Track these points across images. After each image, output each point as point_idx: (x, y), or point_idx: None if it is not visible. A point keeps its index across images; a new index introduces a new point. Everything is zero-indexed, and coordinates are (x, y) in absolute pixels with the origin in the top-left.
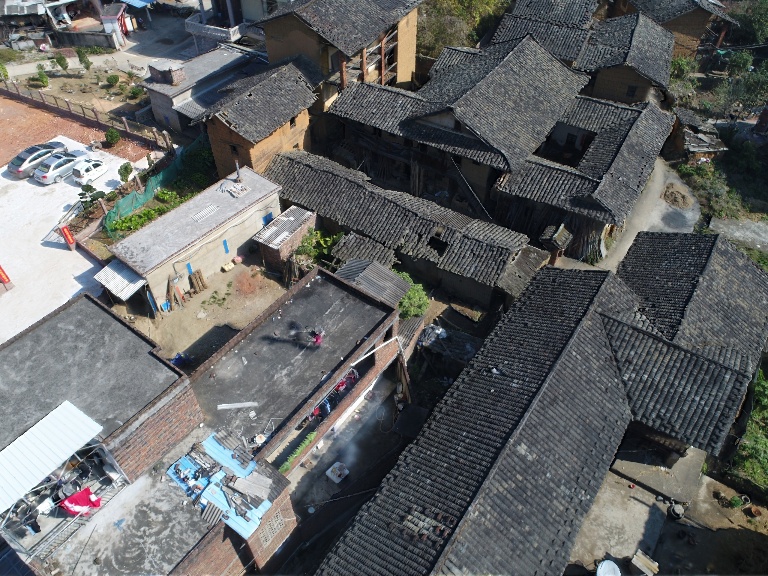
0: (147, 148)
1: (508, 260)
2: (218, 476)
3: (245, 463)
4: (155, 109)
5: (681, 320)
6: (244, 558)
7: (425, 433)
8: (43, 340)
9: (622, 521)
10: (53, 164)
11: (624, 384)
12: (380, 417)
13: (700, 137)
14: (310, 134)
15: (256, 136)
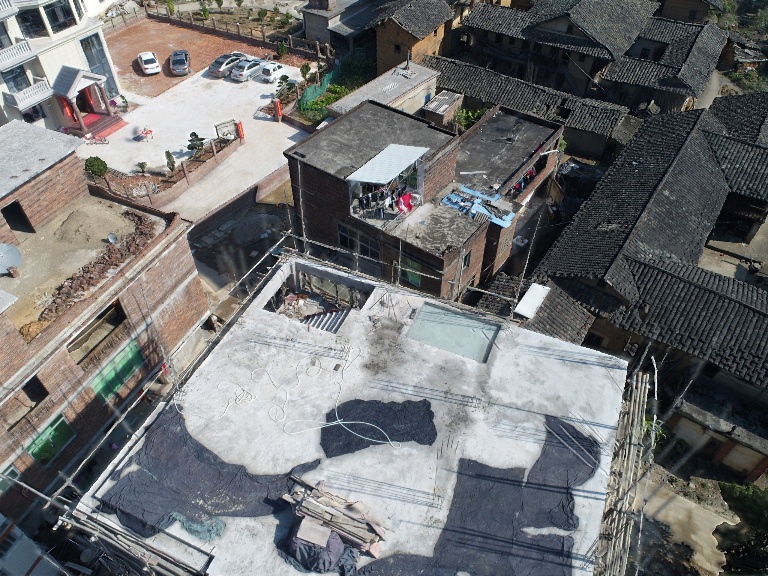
0: (308, 60)
1: (619, 118)
2: (478, 200)
3: (492, 195)
4: (309, 32)
5: (759, 133)
6: (482, 268)
7: (595, 194)
8: (355, 121)
9: (718, 272)
10: (246, 65)
11: (723, 171)
12: (538, 217)
13: (746, 52)
14: (442, 46)
15: (421, 34)
